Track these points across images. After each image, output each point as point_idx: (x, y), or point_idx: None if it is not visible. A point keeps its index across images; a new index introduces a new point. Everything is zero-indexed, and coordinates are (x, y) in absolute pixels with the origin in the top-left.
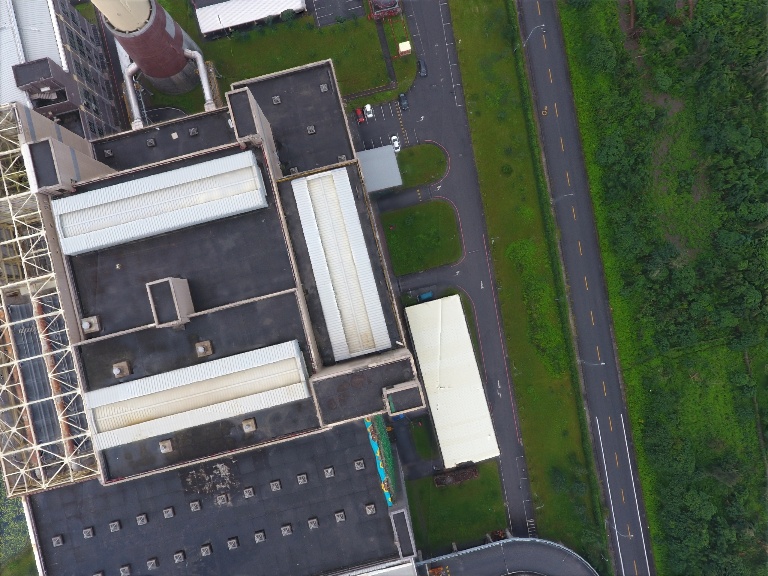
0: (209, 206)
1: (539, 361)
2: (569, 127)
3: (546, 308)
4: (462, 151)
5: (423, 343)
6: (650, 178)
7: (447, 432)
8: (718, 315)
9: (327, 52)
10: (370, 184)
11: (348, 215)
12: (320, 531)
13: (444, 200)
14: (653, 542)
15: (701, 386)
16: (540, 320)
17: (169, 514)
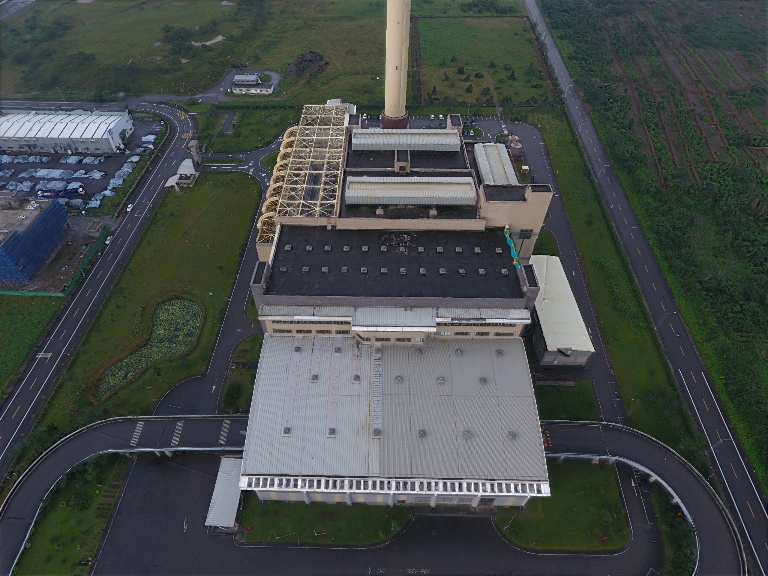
0: (432, 140)
1: (622, 321)
2: (629, 215)
3: (624, 293)
4: (559, 212)
5: None
6: (692, 246)
7: (550, 326)
8: (767, 316)
9: None
10: None
11: (504, 157)
12: (466, 277)
13: (546, 230)
14: (763, 485)
15: None
16: (620, 296)
17: (366, 247)
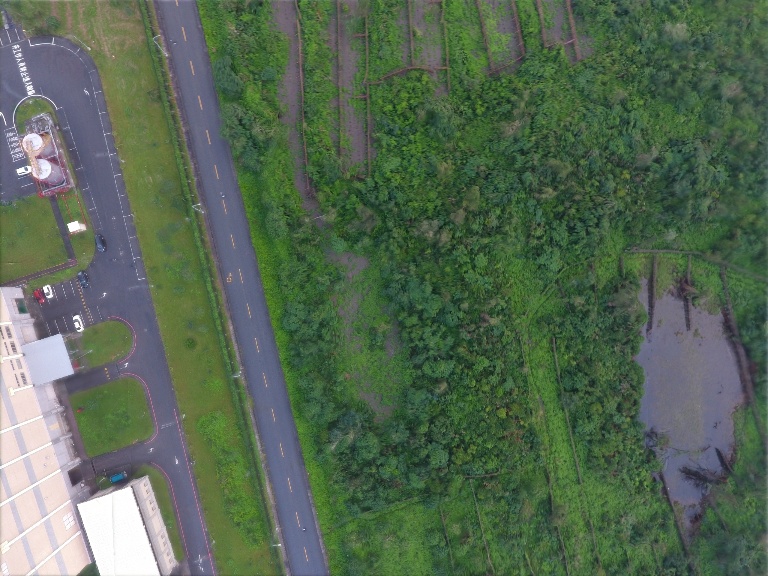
0: None
1: (237, 534)
2: (255, 292)
3: (241, 479)
4: (147, 326)
5: (97, 539)
6: (341, 338)
7: None
8: (406, 478)
9: (1, 233)
10: (40, 377)
11: None
12: None
13: (132, 377)
14: None
15: (399, 545)
16: (233, 494)
17: None
